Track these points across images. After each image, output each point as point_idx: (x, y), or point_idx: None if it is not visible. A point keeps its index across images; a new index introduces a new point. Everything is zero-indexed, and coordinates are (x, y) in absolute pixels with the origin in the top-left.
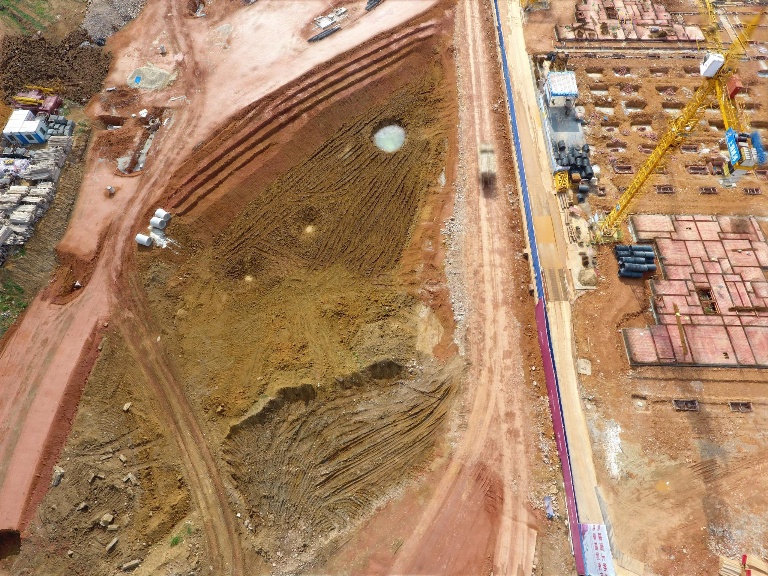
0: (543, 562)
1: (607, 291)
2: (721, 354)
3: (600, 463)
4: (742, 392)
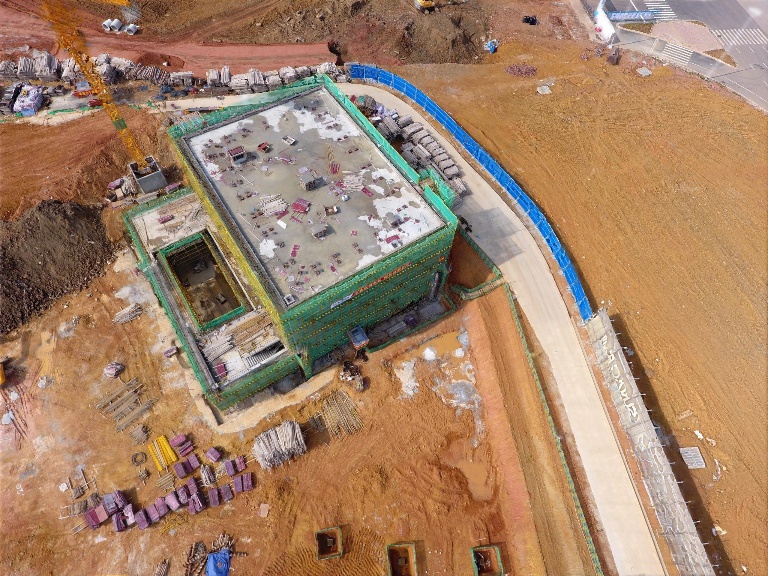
0: None
1: None
2: None
3: None
4: None
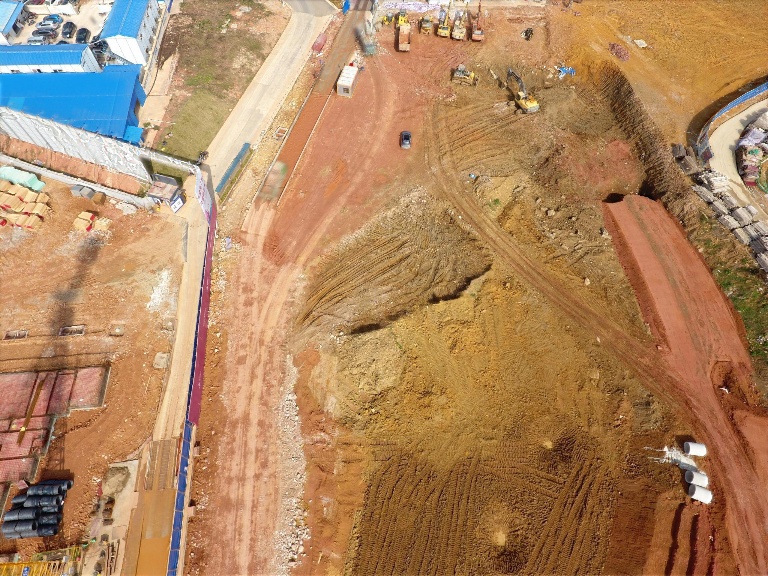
0: (240, 215)
1: (98, 458)
2: (1, 386)
3: (176, 278)
4: (4, 351)
